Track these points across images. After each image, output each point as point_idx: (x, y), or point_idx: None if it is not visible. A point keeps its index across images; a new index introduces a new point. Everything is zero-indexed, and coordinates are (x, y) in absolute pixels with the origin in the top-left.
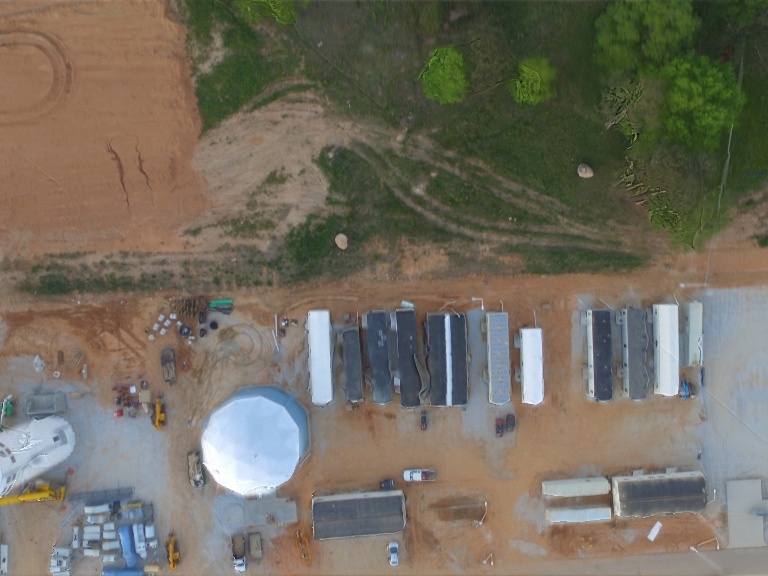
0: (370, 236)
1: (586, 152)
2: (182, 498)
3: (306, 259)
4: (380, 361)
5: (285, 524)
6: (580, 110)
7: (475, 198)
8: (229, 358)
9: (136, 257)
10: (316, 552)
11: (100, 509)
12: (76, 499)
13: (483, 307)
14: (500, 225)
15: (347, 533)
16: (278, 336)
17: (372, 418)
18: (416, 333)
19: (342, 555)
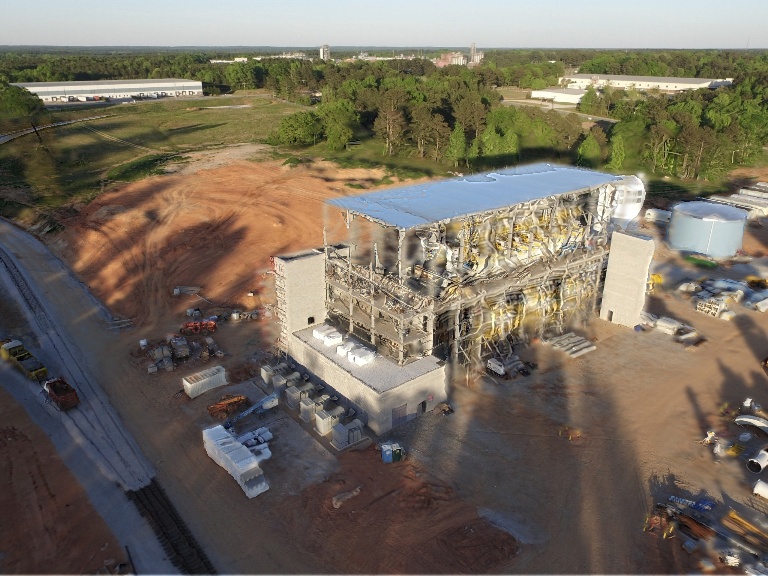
0: None
1: (659, 176)
2: None
3: None
4: None
5: None
6: None
7: None
8: None
9: None
10: None
11: None
12: None
13: None
14: None
15: None
16: None
17: None
18: None
19: None
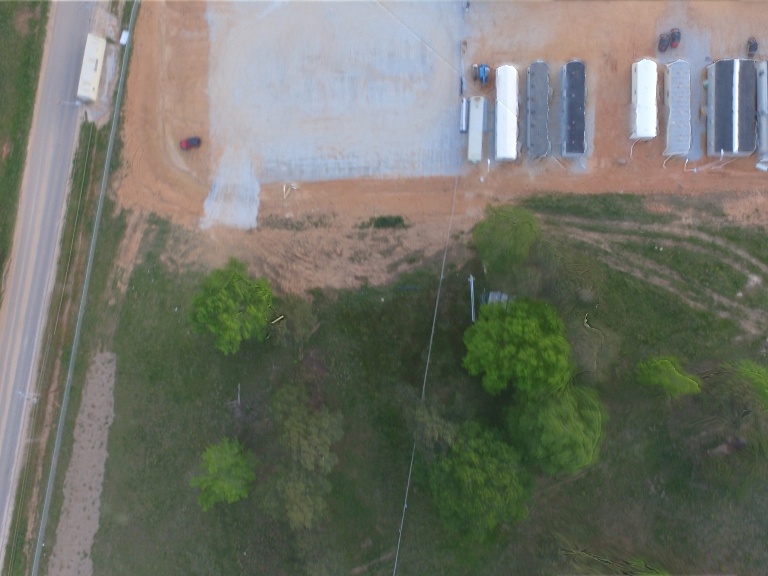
0: None
1: None
2: None
3: None
4: None
5: None
6: None
7: (699, 270)
8: None
9: None
10: None
11: None
12: None
13: (687, 162)
14: (671, 243)
15: None
16: None
17: None
18: None
19: None
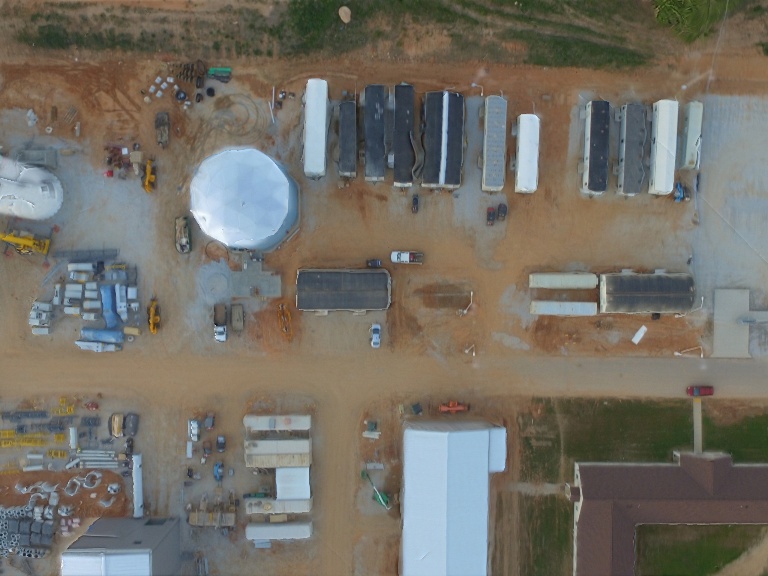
0: (374, 11)
1: None
2: (167, 265)
3: (308, 29)
4: (375, 134)
5: (269, 299)
6: None
7: None
8: (224, 127)
9: (137, 12)
10: (298, 329)
11: (83, 267)
12: (60, 257)
13: (482, 93)
14: (505, 9)
15: (330, 305)
16: (274, 108)
17: (363, 198)
18: (413, 107)
19: (324, 334)
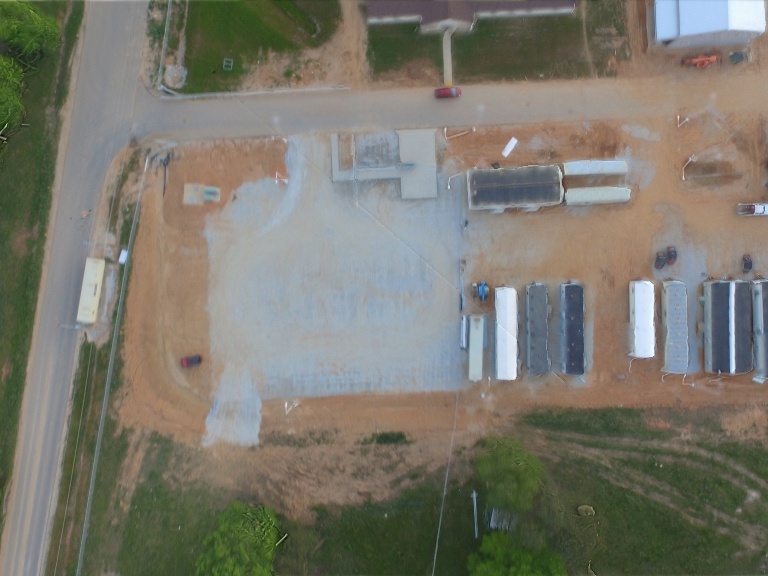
0: None
1: None
2: None
3: None
4: None
5: None
6: (594, 572)
7: (698, 487)
8: None
9: None
10: None
11: None
12: None
13: (685, 377)
14: (671, 459)
15: None
16: None
17: None
18: (766, 356)
19: None
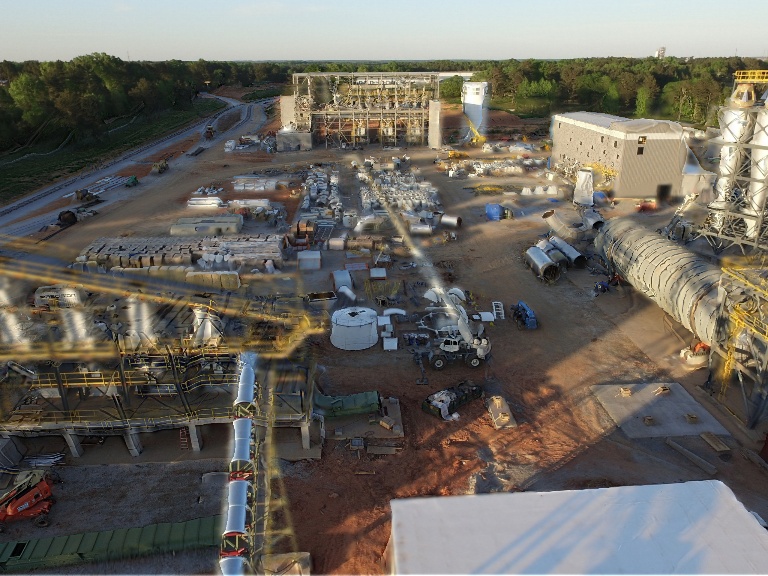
0: None
1: None
2: None
3: None
4: None
5: None
6: None
7: None
8: None
9: None
10: None
11: None
12: None
13: None
14: None
15: None
16: None
17: None
18: None
19: None
